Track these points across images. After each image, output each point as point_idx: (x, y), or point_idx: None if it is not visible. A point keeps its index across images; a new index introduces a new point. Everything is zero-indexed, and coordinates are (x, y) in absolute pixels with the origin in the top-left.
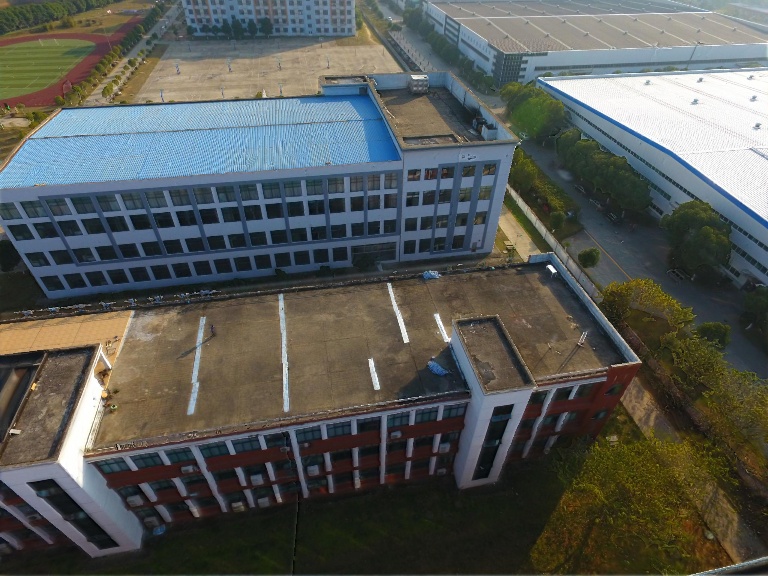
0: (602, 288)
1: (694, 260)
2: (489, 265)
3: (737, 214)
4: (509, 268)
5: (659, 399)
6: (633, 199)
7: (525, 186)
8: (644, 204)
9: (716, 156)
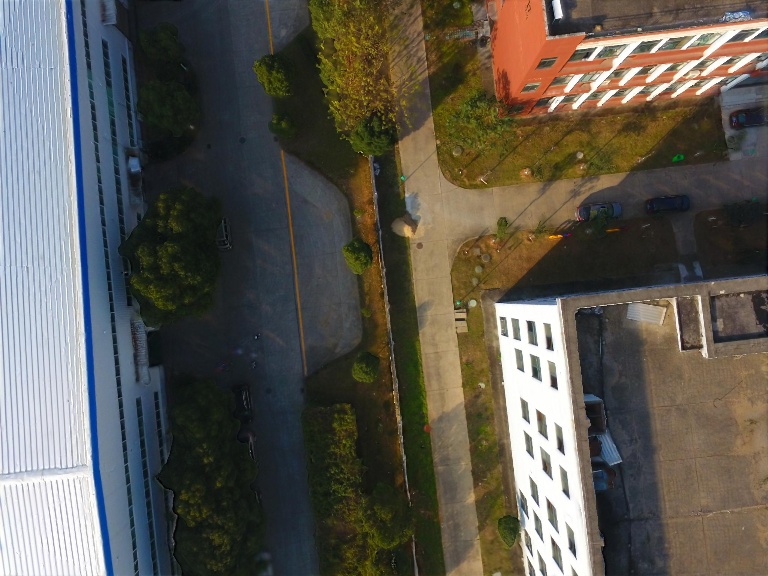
0: (346, 222)
1: (216, 201)
2: (509, 270)
3: (94, 263)
4: (612, 32)
5: (380, 11)
6: (218, 388)
7: (389, 487)
8: (199, 382)
9: (1, 455)
